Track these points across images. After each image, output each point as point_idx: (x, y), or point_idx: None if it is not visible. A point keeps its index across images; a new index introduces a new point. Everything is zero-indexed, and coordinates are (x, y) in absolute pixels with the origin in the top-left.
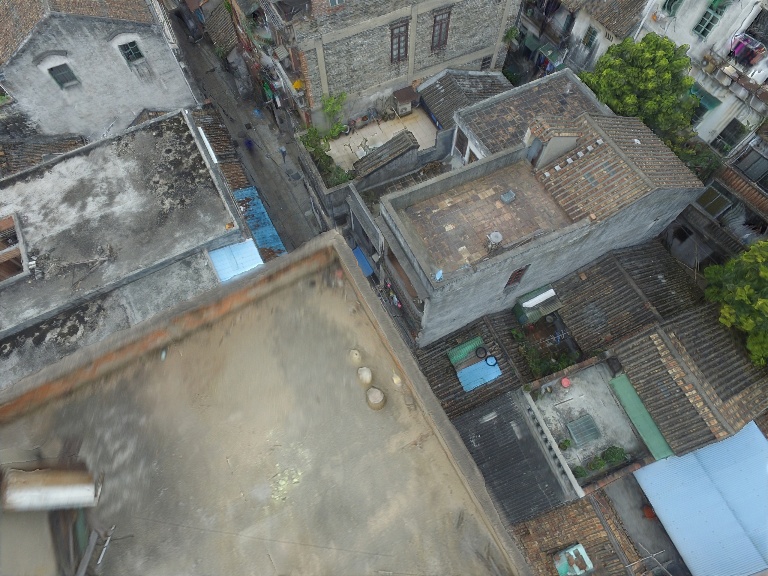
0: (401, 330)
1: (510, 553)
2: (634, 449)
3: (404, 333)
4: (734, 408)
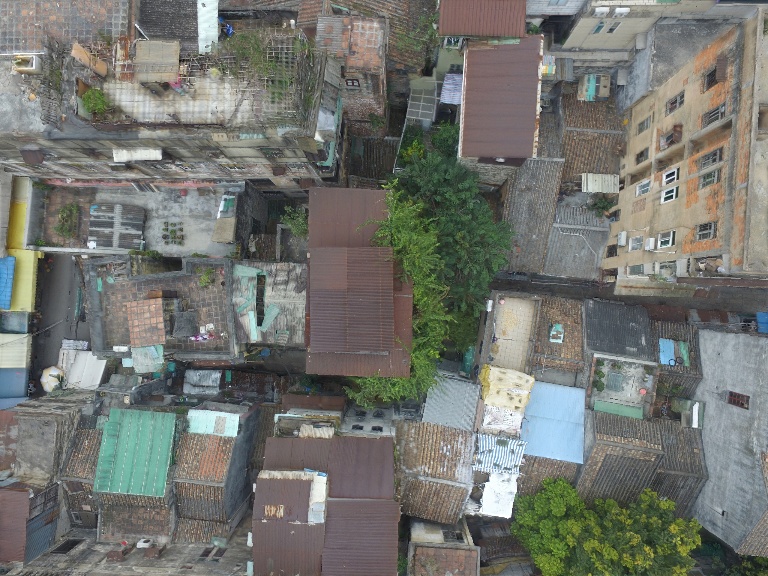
0: (719, 324)
1: (767, 270)
2: (590, 400)
3: (716, 325)
4: (599, 457)
